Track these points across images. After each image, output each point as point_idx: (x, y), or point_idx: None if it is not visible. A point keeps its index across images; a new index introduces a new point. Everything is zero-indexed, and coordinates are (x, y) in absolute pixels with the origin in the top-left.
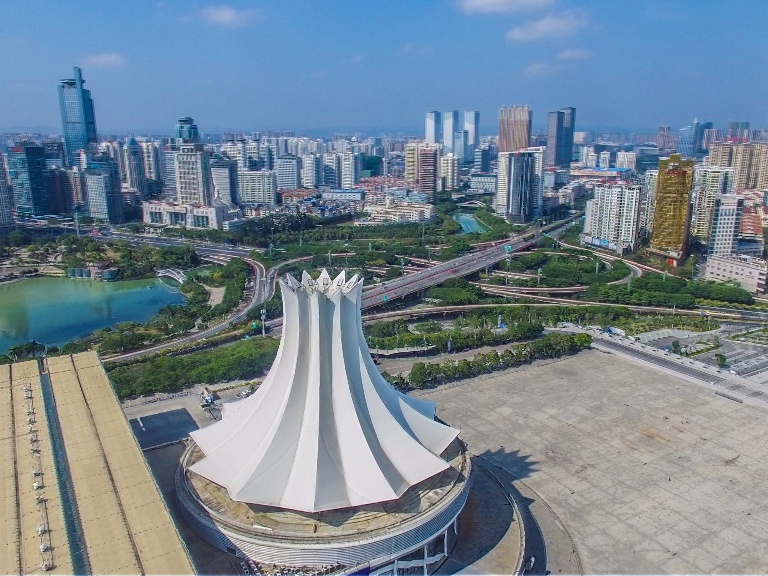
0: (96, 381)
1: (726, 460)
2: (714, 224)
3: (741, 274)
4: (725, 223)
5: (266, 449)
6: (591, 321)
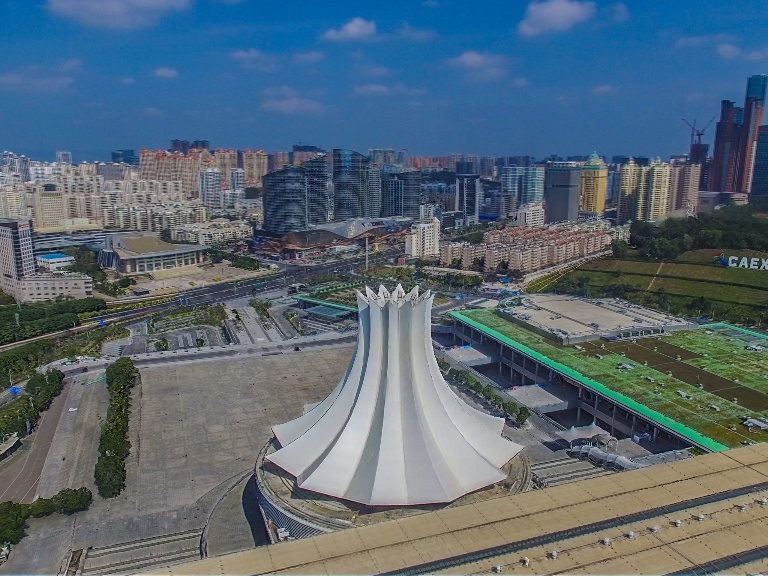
0: (195, 572)
1: None
2: (18, 247)
3: (66, 288)
4: (25, 244)
5: None
6: (42, 361)
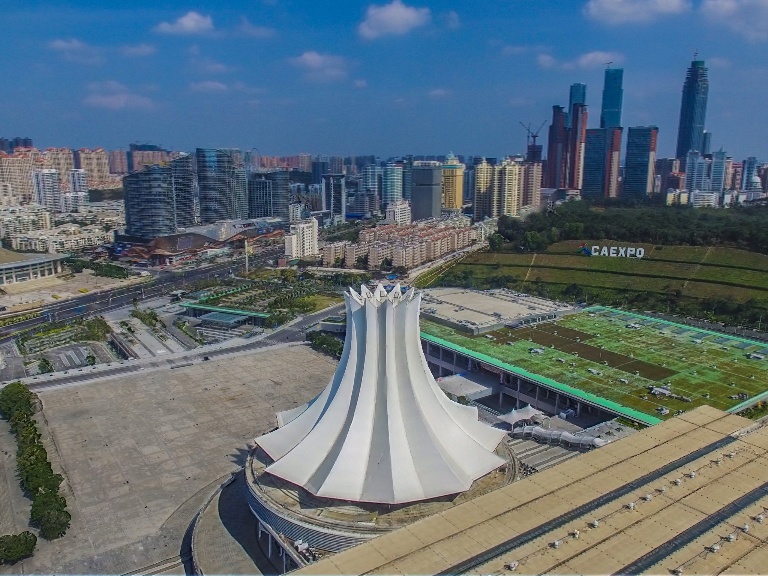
0: None
1: (275, 384)
2: None
3: None
4: None
5: (463, 431)
6: None
